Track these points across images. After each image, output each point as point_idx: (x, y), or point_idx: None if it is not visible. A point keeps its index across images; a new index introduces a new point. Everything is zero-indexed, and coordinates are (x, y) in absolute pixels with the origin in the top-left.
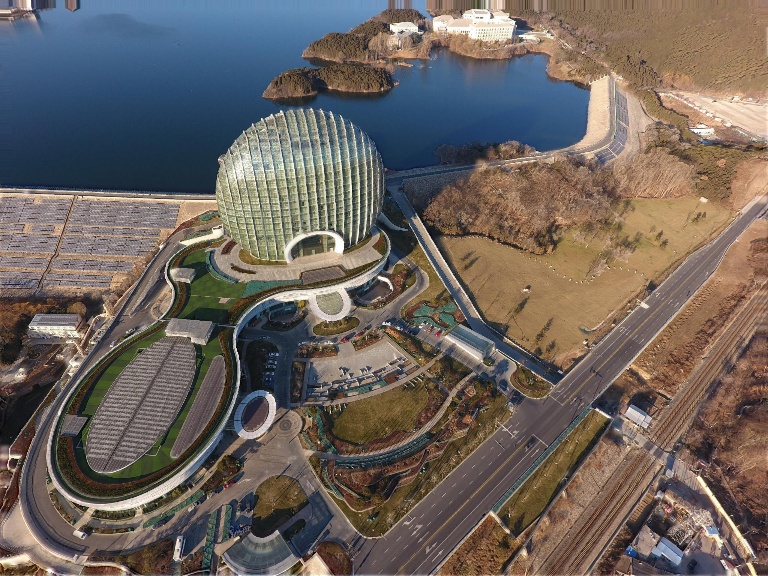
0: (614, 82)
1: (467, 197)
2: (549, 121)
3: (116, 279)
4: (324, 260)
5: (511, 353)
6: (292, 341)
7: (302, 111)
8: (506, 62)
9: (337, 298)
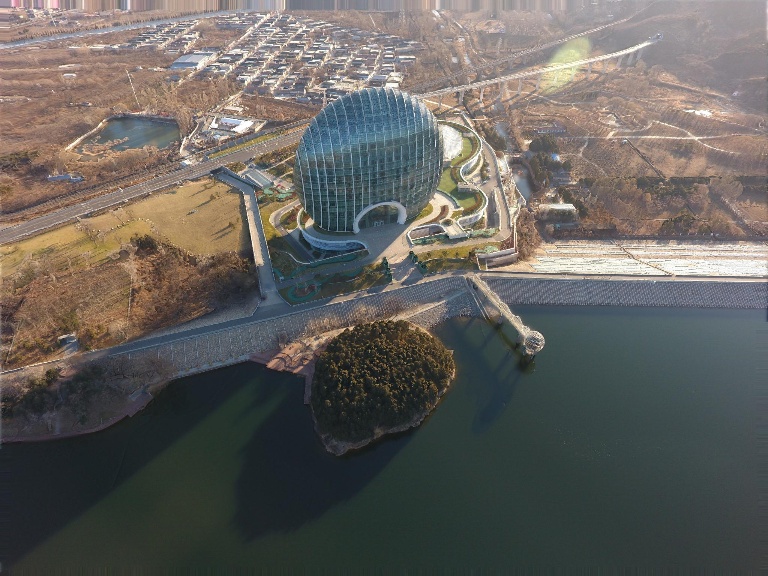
0: None
1: None
2: None
3: None
4: None
5: (235, 182)
6: None
7: None
8: None
9: None
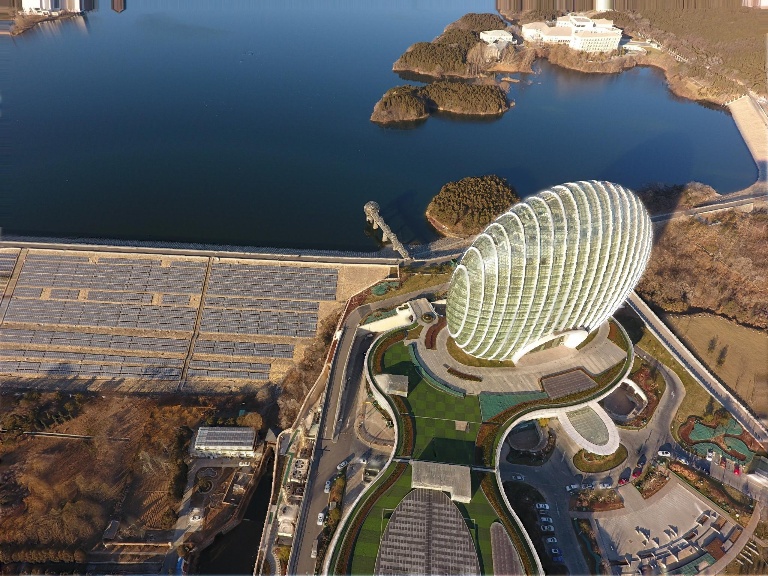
0: (759, 104)
1: (679, 261)
2: (703, 152)
3: (275, 368)
4: (558, 359)
5: None
6: (555, 482)
7: (591, 187)
8: (614, 76)
9: (594, 417)
